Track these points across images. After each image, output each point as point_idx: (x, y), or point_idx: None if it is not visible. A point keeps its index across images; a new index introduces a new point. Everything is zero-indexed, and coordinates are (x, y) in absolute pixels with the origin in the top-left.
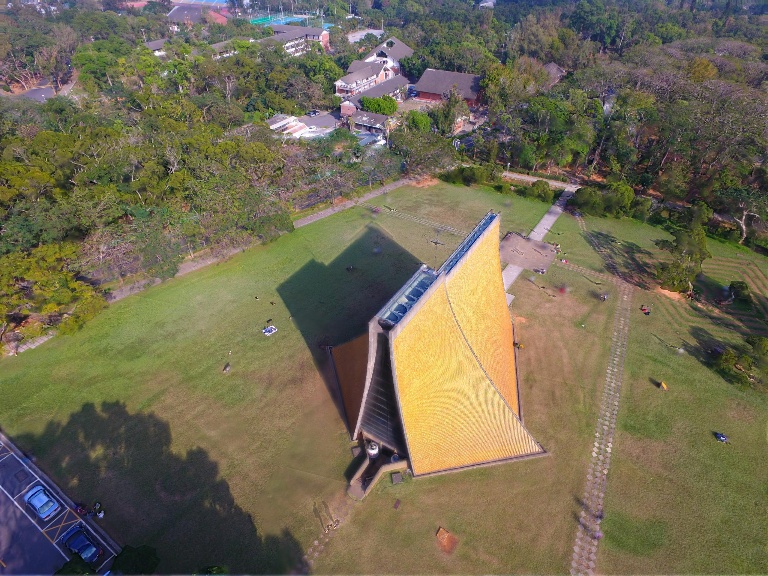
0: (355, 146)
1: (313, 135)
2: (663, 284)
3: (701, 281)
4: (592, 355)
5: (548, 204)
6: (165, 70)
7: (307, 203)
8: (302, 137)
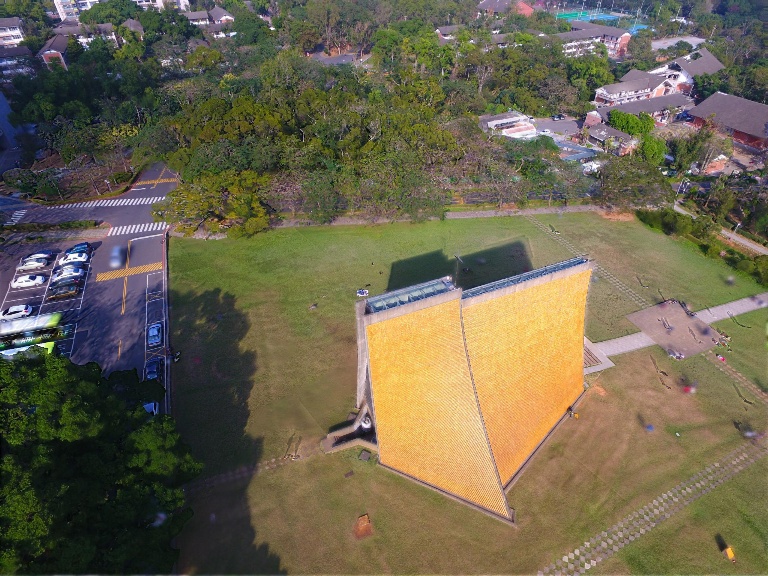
0: (553, 157)
1: None
2: None
3: None
4: (658, 468)
5: (763, 288)
6: (439, 53)
7: (474, 199)
8: (504, 136)
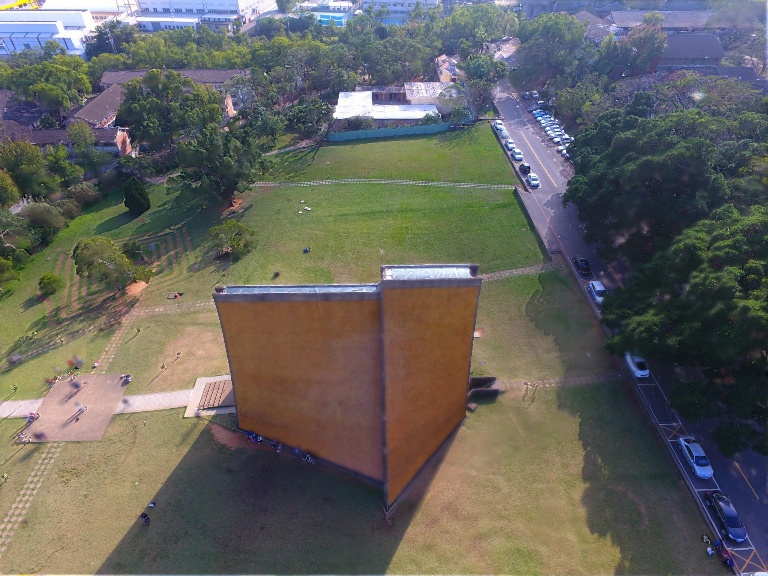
0: None
1: None
2: (146, 279)
3: None
4: None
5: None
6: None
7: None
8: None
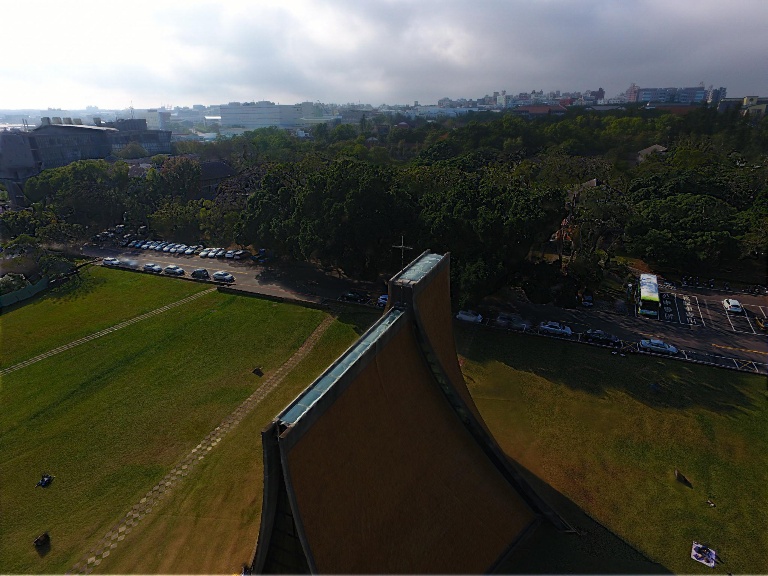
0: None
1: None
2: None
3: None
4: None
5: None
6: None
7: None
8: None
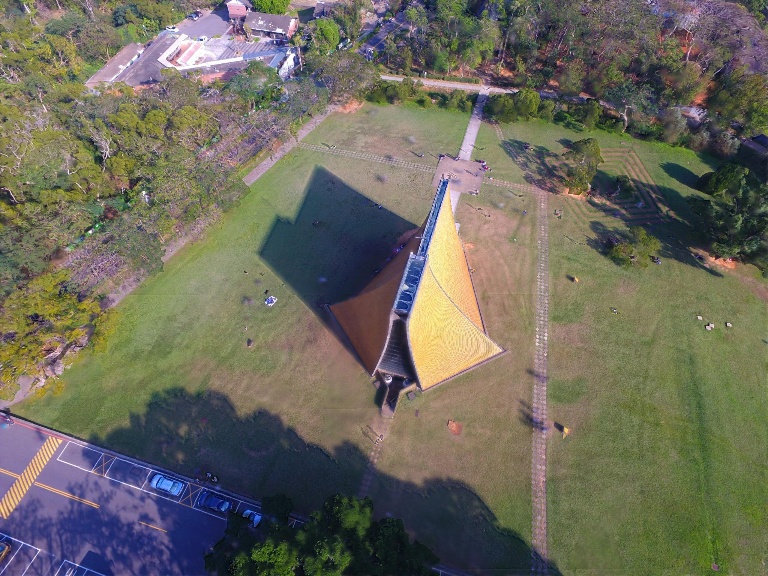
0: (275, 79)
1: (217, 60)
2: (570, 190)
3: (596, 177)
4: (525, 266)
5: (467, 114)
6: None
7: None
8: (217, 78)
